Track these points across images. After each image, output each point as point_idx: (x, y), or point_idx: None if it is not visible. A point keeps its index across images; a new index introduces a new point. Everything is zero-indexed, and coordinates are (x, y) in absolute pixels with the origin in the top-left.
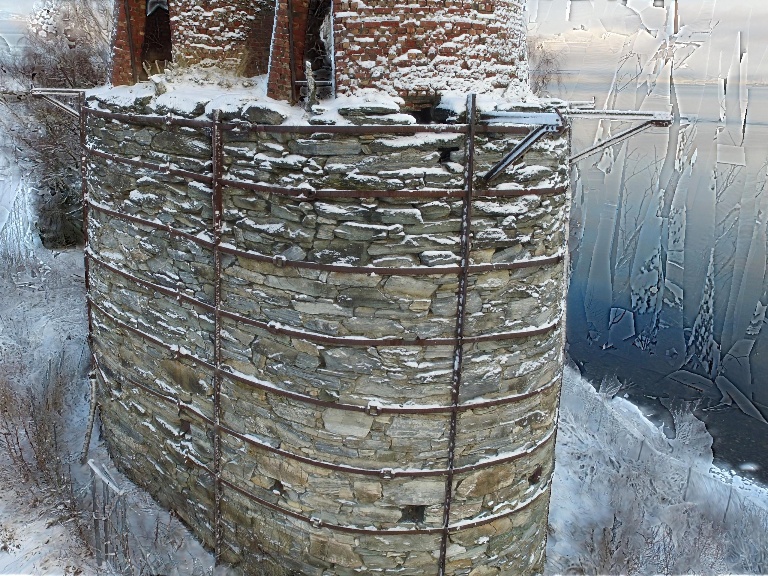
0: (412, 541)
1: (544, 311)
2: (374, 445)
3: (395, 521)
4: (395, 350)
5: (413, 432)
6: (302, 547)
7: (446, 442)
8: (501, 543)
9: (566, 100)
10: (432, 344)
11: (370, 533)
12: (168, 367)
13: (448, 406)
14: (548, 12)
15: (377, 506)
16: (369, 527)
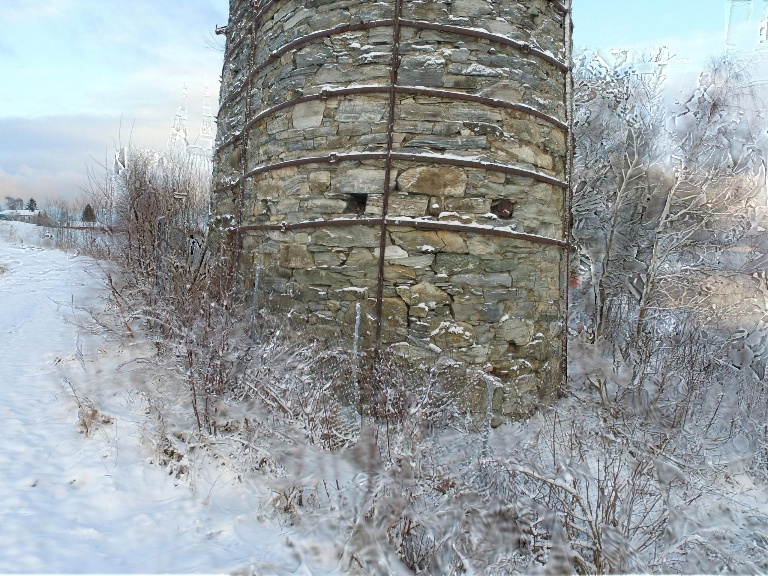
0: (355, 236)
1: (500, 21)
2: (325, 131)
3: (340, 211)
4: (343, 35)
5: (357, 116)
6: (275, 261)
7: (385, 124)
8: (451, 263)
9: (759, 109)
10: (373, 26)
11: (319, 225)
12: (231, 159)
13: (386, 86)
14: (739, 32)
15: (326, 196)
16: (318, 219)
